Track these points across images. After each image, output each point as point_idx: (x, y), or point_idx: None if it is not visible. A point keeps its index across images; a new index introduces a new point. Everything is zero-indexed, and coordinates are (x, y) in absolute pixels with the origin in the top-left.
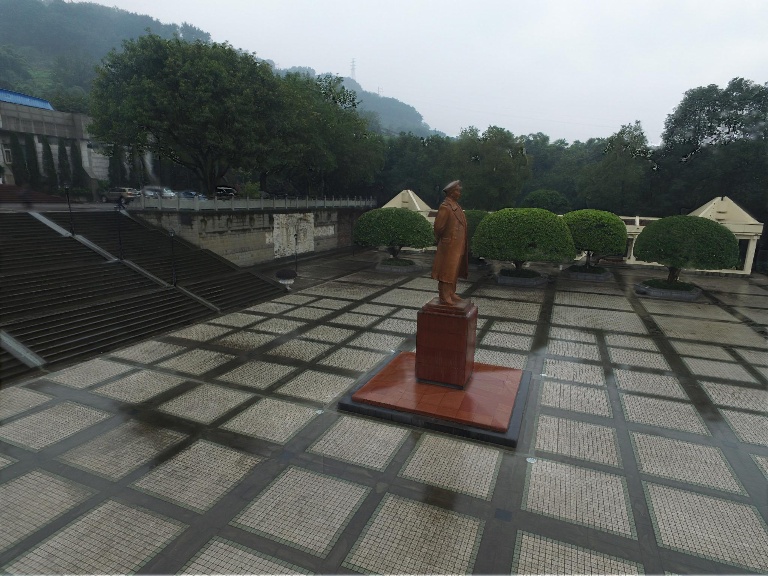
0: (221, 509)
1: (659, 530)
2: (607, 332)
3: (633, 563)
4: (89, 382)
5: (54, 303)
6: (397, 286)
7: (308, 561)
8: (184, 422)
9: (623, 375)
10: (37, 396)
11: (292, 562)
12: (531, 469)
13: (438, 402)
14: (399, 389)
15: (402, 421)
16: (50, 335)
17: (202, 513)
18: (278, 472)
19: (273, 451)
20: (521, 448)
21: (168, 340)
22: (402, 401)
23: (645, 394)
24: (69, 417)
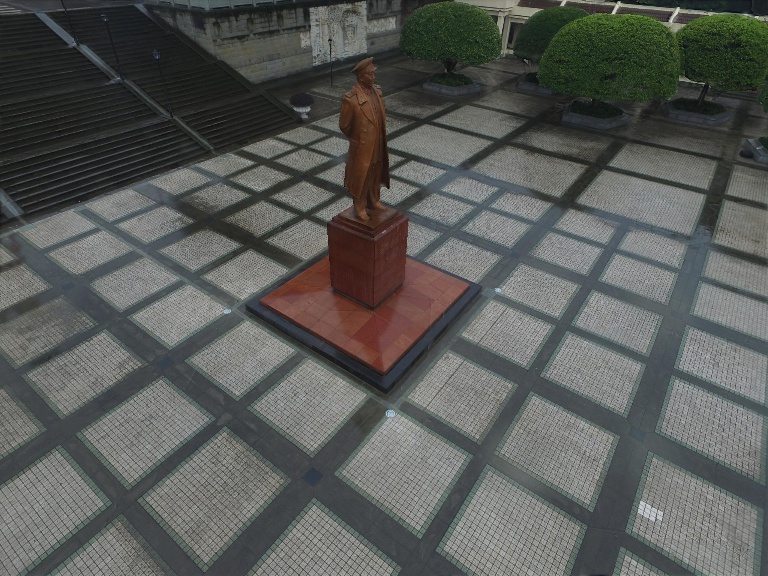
0: (79, 417)
1: (452, 532)
2: (636, 226)
3: (393, 564)
4: (51, 241)
5: (44, 139)
6: (430, 120)
7: (114, 489)
8: (102, 306)
9: (596, 303)
10: (3, 254)
11: (101, 487)
12: (381, 425)
13: (337, 323)
14: (309, 298)
15: (295, 338)
16: (32, 180)
17: (62, 418)
18: (147, 383)
19: (157, 356)
20: (392, 395)
21: (144, 190)
22: (303, 315)
23: (598, 338)
24: (15, 285)
